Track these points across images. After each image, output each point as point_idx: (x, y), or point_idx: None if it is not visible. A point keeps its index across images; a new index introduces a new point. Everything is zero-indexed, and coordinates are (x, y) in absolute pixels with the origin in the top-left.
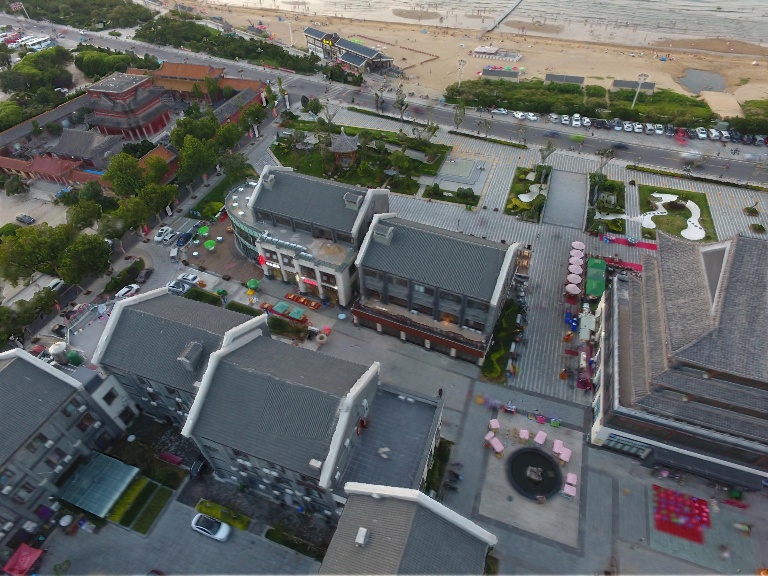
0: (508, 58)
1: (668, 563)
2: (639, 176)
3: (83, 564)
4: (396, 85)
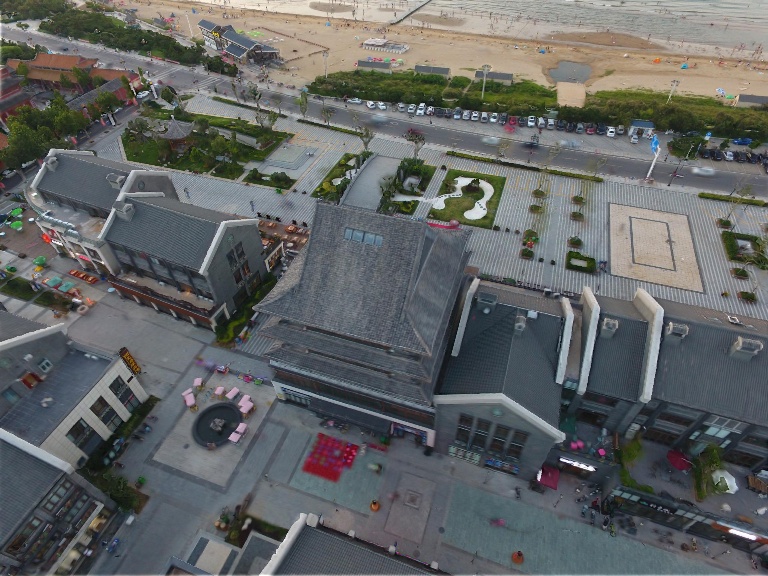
0: (394, 50)
1: (297, 498)
2: (454, 161)
3: None
4: (272, 76)
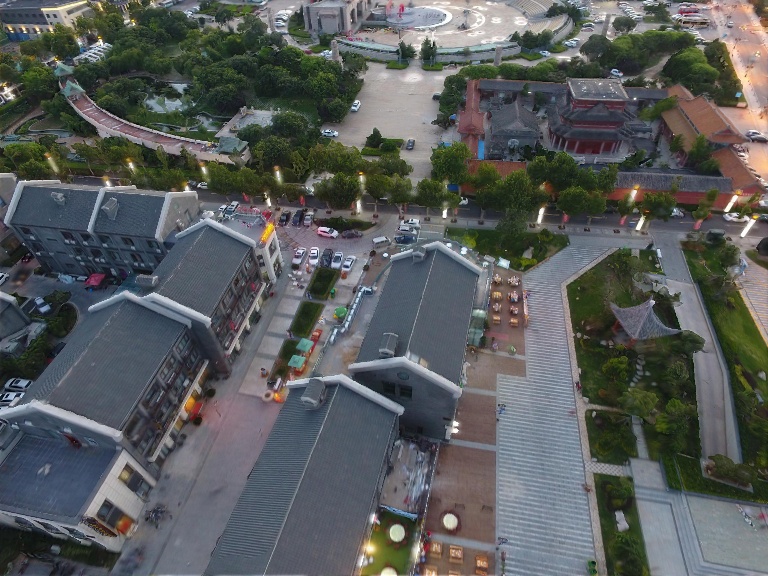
0: None
1: None
2: None
3: None
4: None
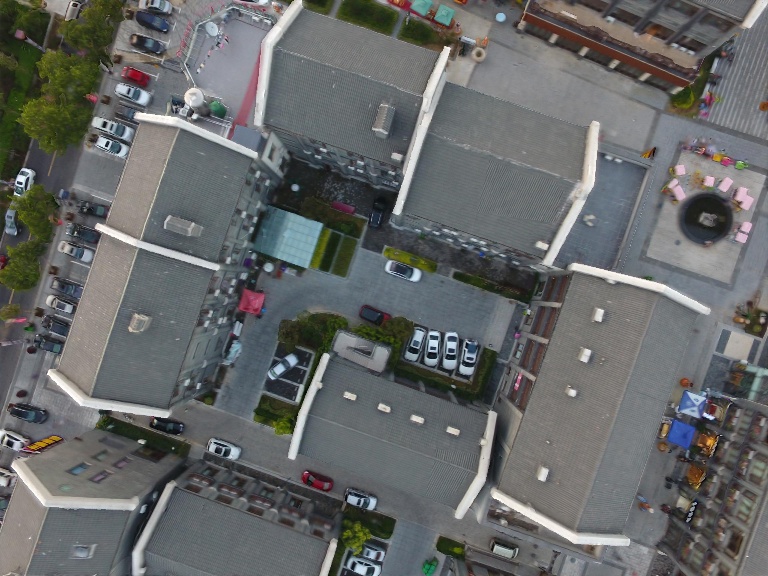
0: None
1: None
2: None
3: (300, 300)
4: None
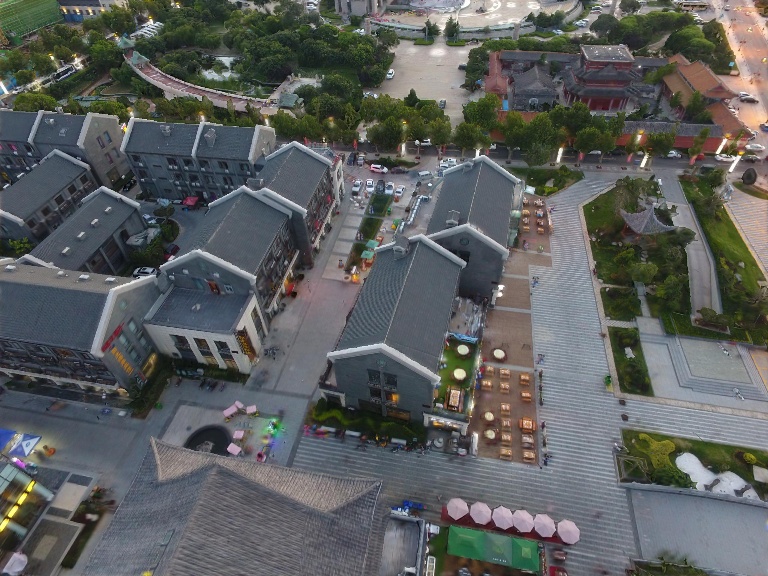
0: None
1: None
2: None
3: (190, 223)
4: None
